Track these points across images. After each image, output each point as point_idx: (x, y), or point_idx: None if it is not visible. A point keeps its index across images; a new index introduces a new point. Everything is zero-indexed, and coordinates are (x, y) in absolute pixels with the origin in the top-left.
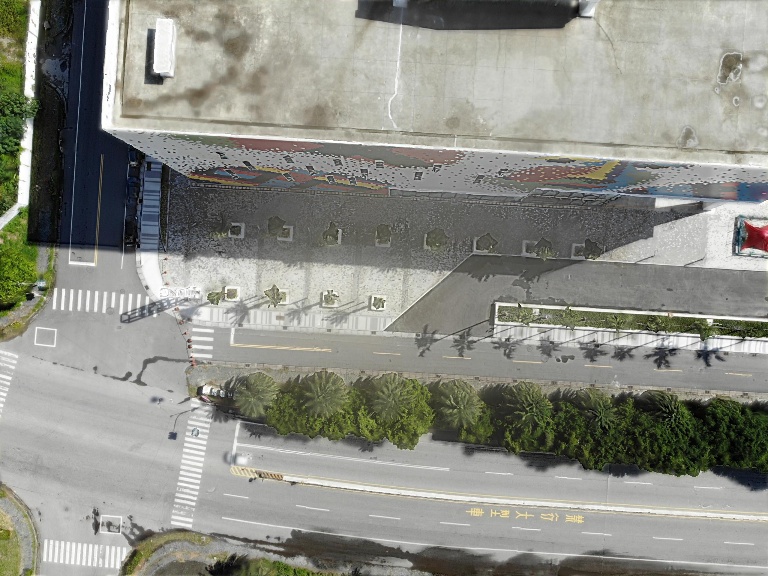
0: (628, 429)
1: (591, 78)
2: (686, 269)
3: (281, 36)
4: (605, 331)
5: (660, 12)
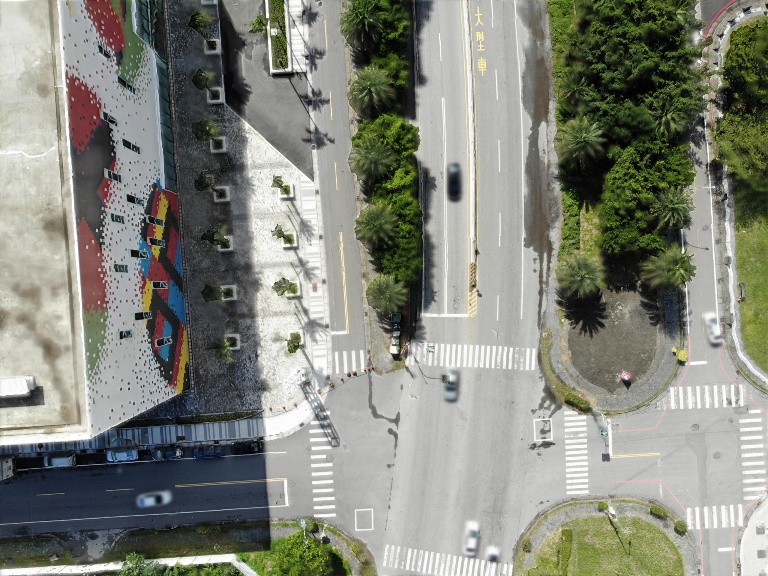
0: None
1: None
2: None
3: None
4: None
5: None
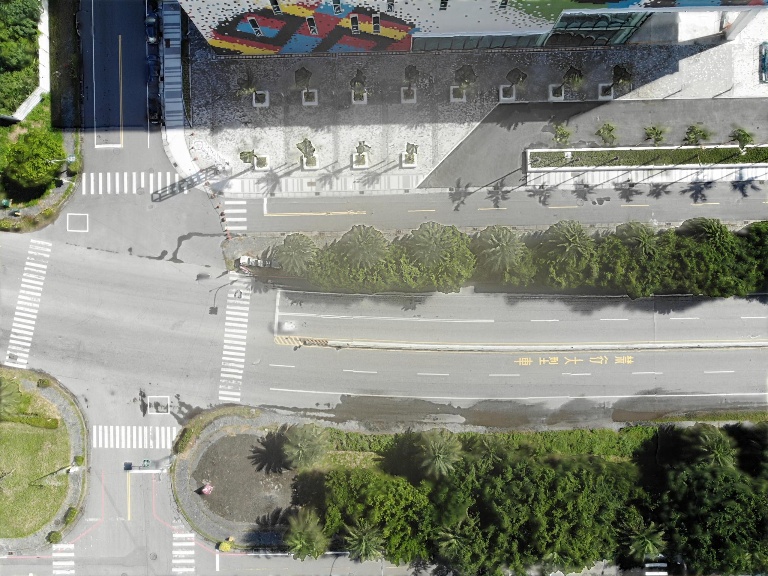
0: (673, 253)
1: None
2: (714, 101)
3: None
4: (639, 170)
5: None
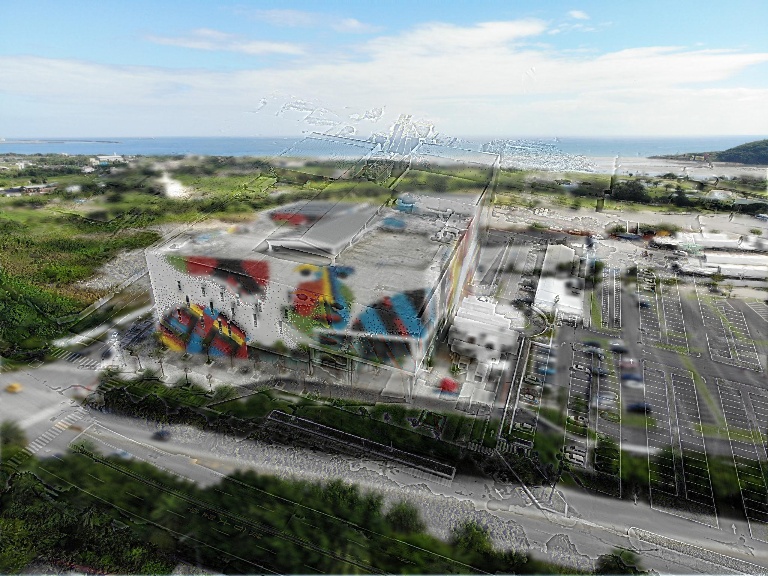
0: None
1: (325, 279)
2: (388, 425)
3: (224, 249)
4: (329, 439)
5: (359, 271)
